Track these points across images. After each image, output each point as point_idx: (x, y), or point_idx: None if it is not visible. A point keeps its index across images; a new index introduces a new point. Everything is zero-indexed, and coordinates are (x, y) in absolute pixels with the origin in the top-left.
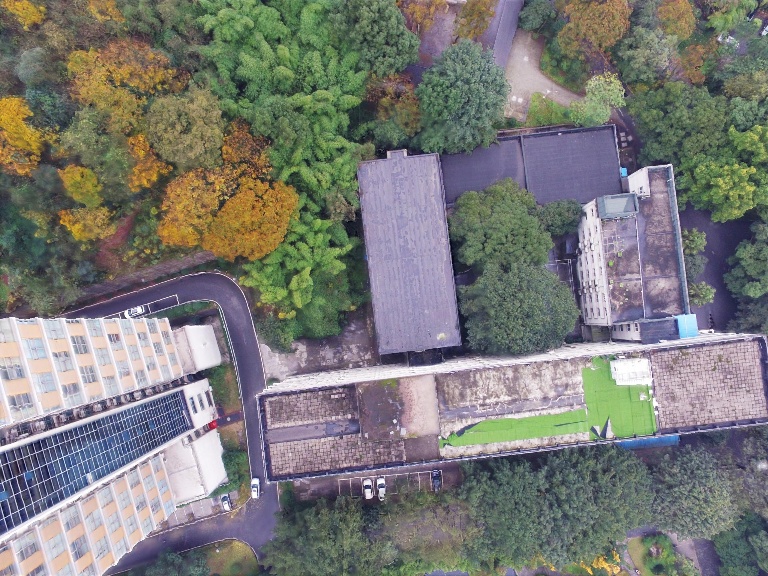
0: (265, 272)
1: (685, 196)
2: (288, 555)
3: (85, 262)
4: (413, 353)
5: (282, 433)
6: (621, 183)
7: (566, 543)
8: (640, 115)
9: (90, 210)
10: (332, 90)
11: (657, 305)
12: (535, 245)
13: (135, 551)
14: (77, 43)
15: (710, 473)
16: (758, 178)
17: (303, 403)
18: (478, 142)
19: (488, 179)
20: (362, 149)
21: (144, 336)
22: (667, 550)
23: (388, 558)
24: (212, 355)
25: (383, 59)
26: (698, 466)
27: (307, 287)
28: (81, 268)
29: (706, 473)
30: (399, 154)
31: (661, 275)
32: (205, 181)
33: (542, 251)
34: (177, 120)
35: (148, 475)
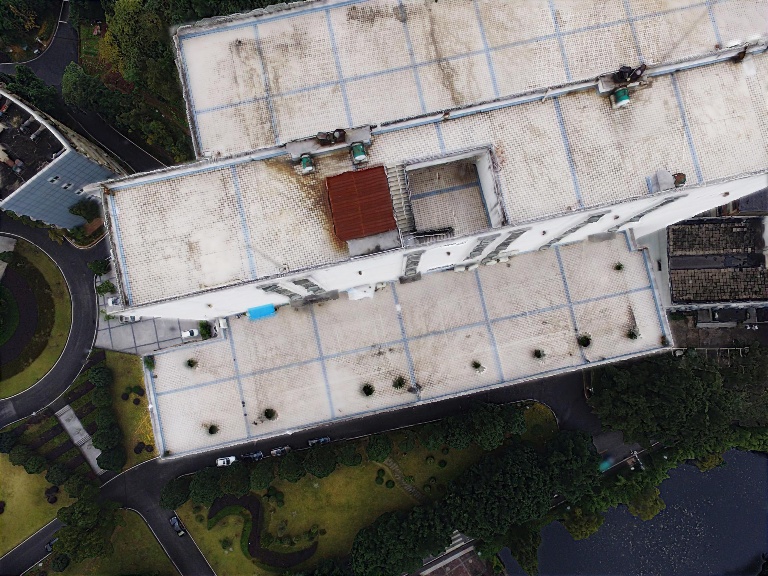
0: None
1: None
2: (641, 398)
3: None
4: None
5: (682, 261)
6: None
7: None
8: None
9: None
10: None
11: None
12: None
13: (438, 404)
14: None
15: None
16: None
17: (705, 234)
18: None
19: None
20: None
21: None
22: None
23: None
24: None
25: None
26: None
27: None
28: None
29: None
30: None
31: None
32: None
33: None
34: None
35: None
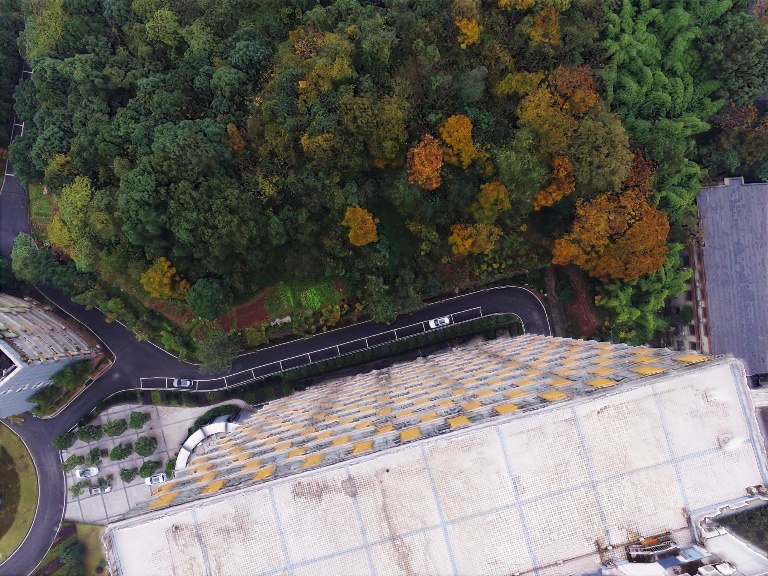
0: (625, 293)
1: None
2: None
3: (436, 274)
4: None
5: None
6: None
7: None
8: None
9: (485, 226)
10: None
11: None
12: None
13: None
14: (522, 64)
15: None
16: None
17: None
18: None
19: None
20: (701, 175)
21: None
22: None
23: None
24: None
25: (749, 89)
26: None
27: None
28: (433, 279)
29: None
30: (737, 181)
31: None
32: (620, 204)
33: None
34: (601, 143)
35: None
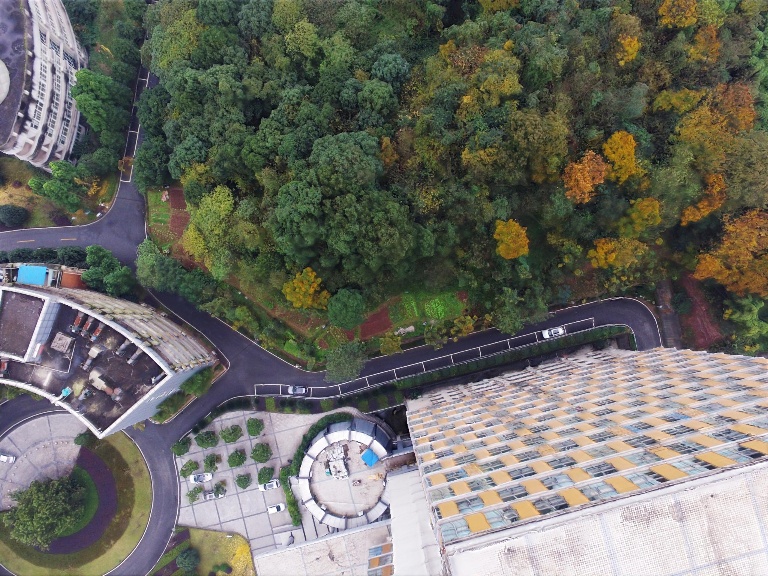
0: (757, 307)
1: None
2: None
3: (566, 286)
4: None
5: None
6: None
7: None
8: None
9: None
10: None
11: None
12: None
13: None
14: (683, 81)
15: None
16: None
17: None
18: None
19: None
20: None
21: None
22: None
23: None
24: None
25: None
26: None
27: None
28: (562, 291)
29: None
30: None
31: None
32: None
33: None
34: None
35: None
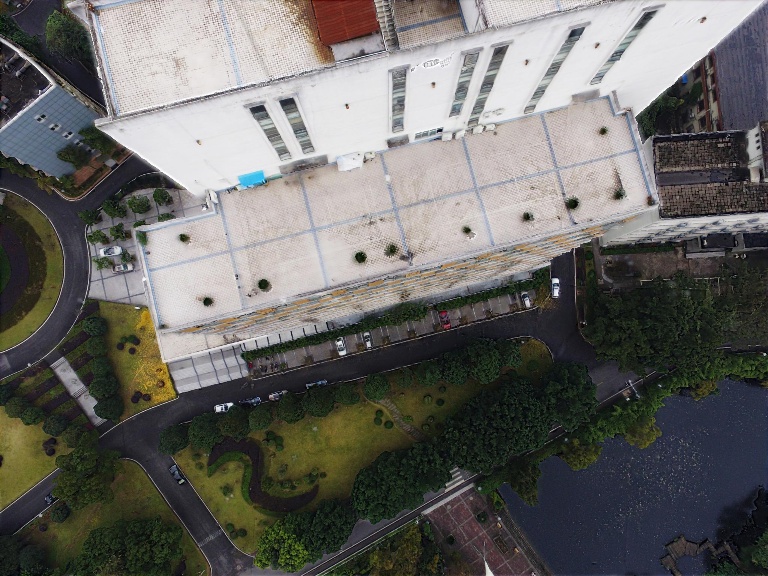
0: None
1: None
2: (634, 320)
3: None
4: None
5: (669, 178)
6: None
7: None
8: None
9: None
10: None
11: None
12: None
13: (433, 344)
14: None
15: None
16: None
17: (690, 150)
18: None
19: None
20: None
21: None
22: None
23: None
24: None
25: None
26: None
27: None
28: None
29: None
30: None
31: None
32: None
33: None
34: None
35: None
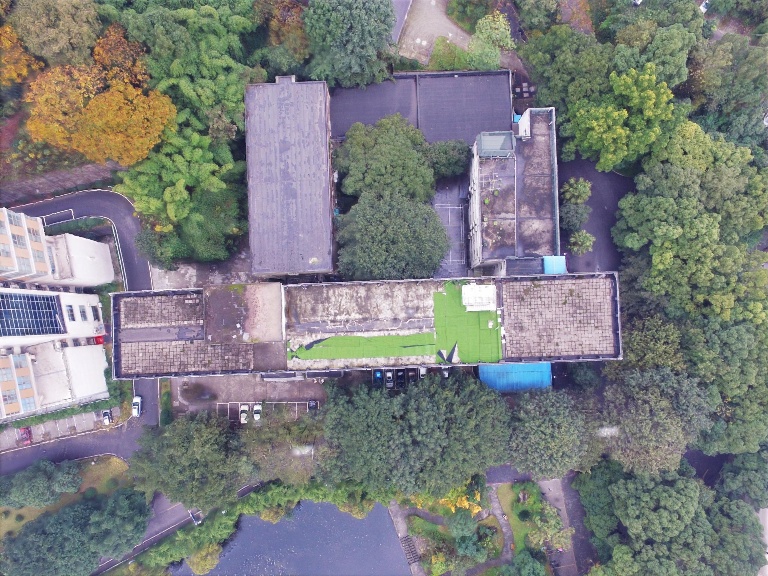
0: (139, 180)
1: (572, 144)
2: (146, 462)
3: None
4: (291, 279)
5: (135, 334)
6: (512, 128)
7: (416, 470)
8: (528, 58)
9: None
10: (221, 9)
11: (529, 246)
12: (411, 177)
13: (16, 459)
14: None
15: (562, 411)
16: (633, 124)
17: (157, 306)
18: (368, 74)
19: (381, 115)
20: (251, 72)
21: (0, 224)
22: (534, 497)
23: (252, 479)
24: (101, 270)
25: None
26: (553, 405)
27: (185, 202)
28: None
29: (558, 411)
30: (287, 79)
31: (536, 216)
32: (70, 76)
33: (417, 183)
34: (45, 14)
35: (6, 367)
